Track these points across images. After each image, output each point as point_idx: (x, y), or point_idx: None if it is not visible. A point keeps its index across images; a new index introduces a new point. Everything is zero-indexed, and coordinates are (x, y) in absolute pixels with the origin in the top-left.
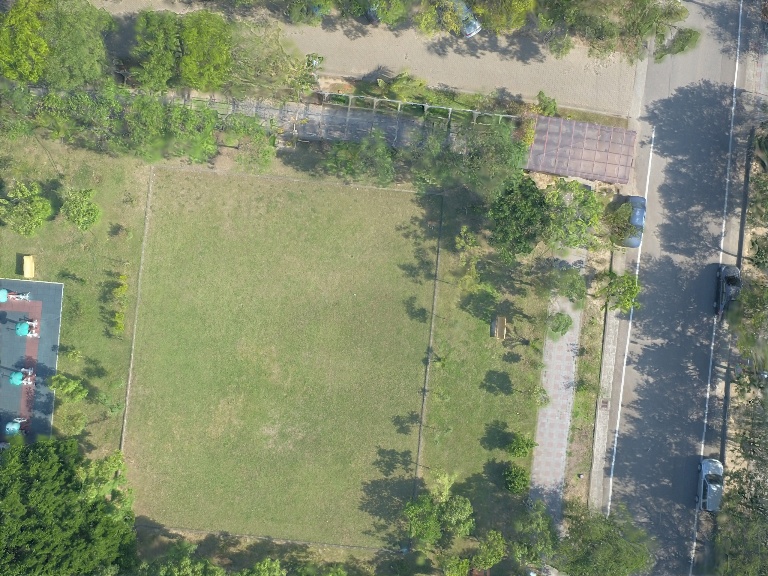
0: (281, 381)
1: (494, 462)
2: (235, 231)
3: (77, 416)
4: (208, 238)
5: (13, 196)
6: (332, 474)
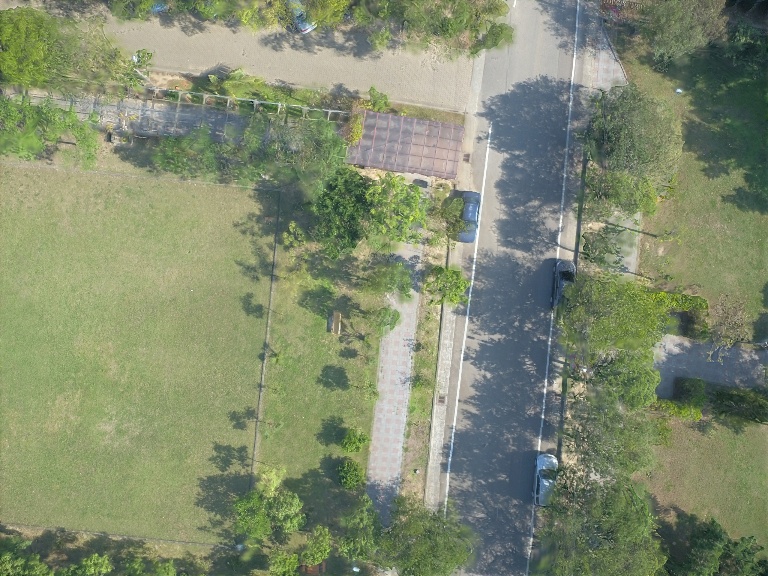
0: (118, 377)
1: (330, 458)
2: (73, 227)
3: None
4: (46, 234)
5: None
6: (168, 470)
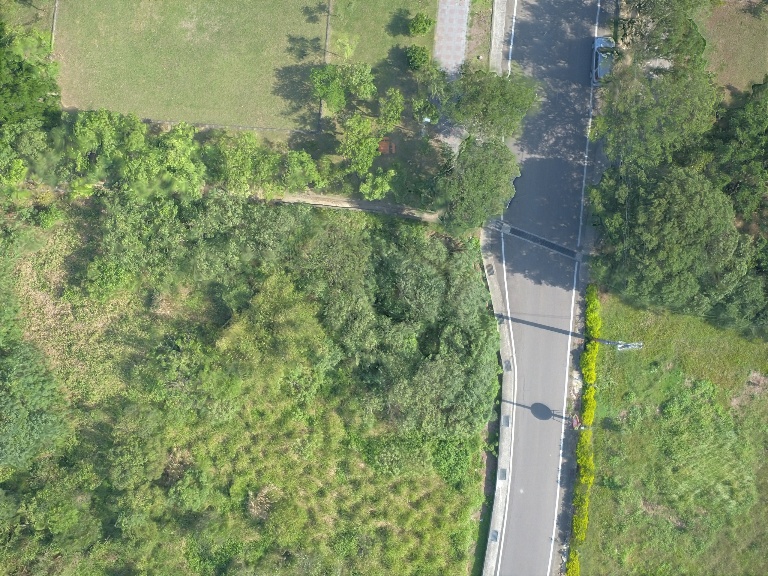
0: None
1: (398, 48)
2: None
3: (7, 2)
4: None
5: None
6: (246, 62)
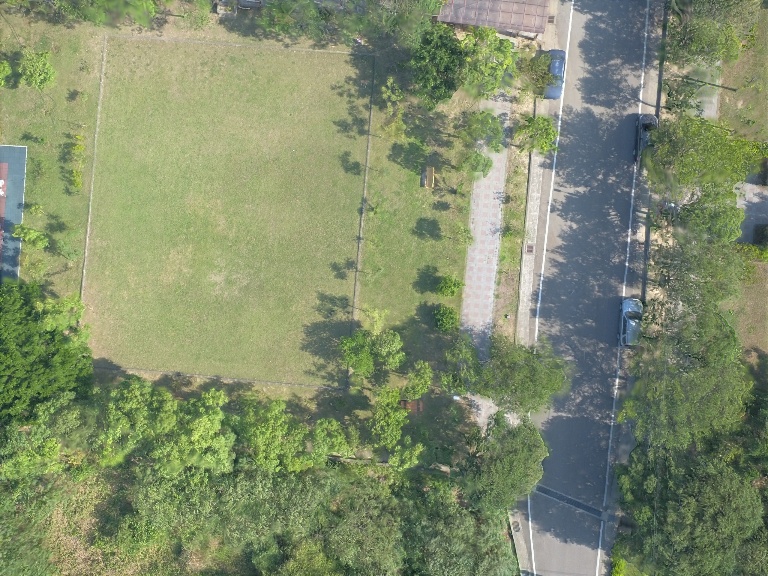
0: (226, 232)
1: (426, 305)
2: (182, 94)
3: (38, 262)
4: (158, 101)
5: None
6: (274, 317)
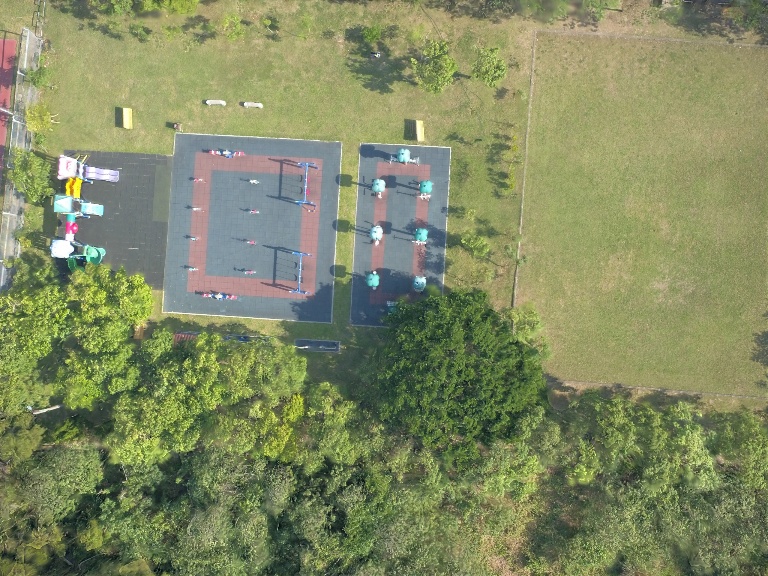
0: (669, 236)
1: None
2: (619, 92)
3: (484, 269)
4: (593, 99)
5: (426, 54)
6: (723, 326)
